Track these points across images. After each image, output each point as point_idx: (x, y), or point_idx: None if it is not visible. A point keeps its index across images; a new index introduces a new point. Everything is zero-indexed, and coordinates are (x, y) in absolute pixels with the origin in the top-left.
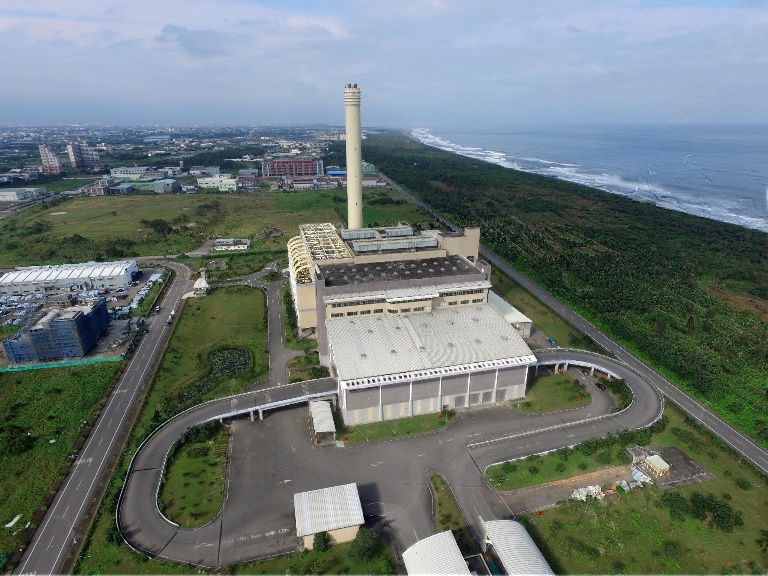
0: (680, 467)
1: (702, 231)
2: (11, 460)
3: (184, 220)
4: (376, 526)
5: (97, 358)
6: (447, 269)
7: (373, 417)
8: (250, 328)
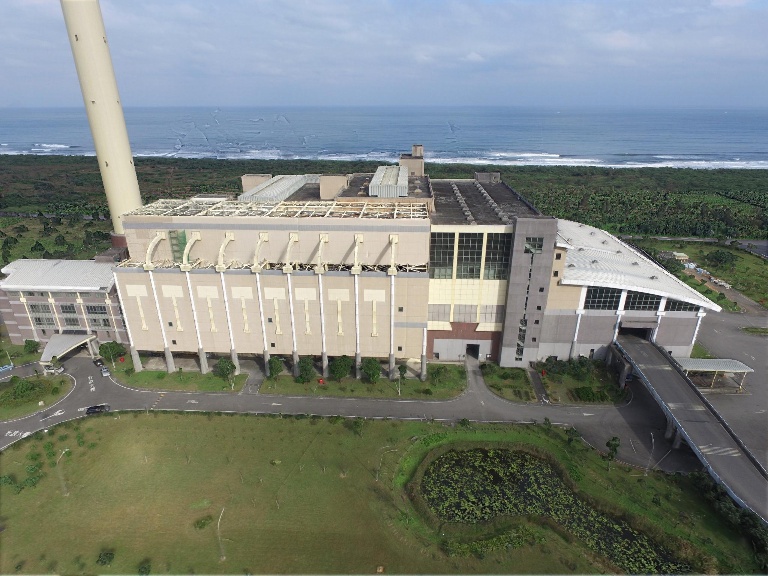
0: None
1: (299, 167)
2: None
3: None
4: None
5: None
6: None
7: None
8: (330, 443)
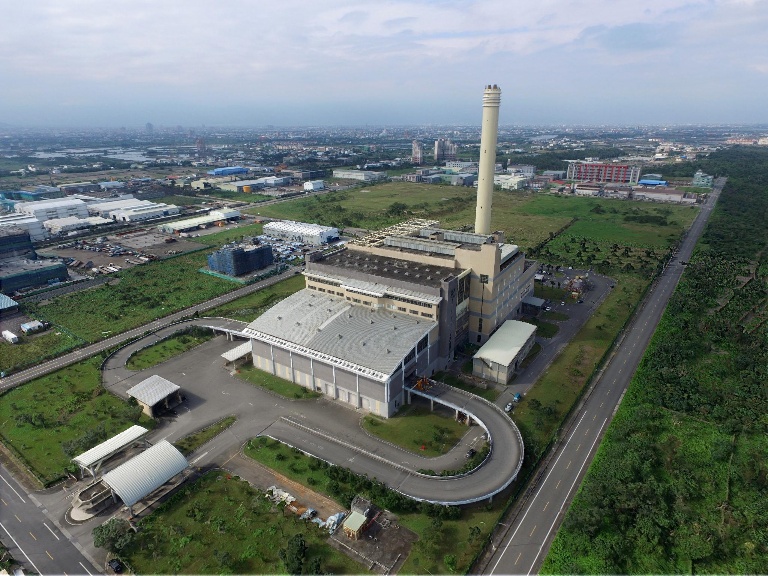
0: (380, 547)
1: None
2: (142, 309)
3: (421, 207)
4: (167, 418)
5: (239, 279)
6: (424, 277)
7: (269, 368)
8: None
